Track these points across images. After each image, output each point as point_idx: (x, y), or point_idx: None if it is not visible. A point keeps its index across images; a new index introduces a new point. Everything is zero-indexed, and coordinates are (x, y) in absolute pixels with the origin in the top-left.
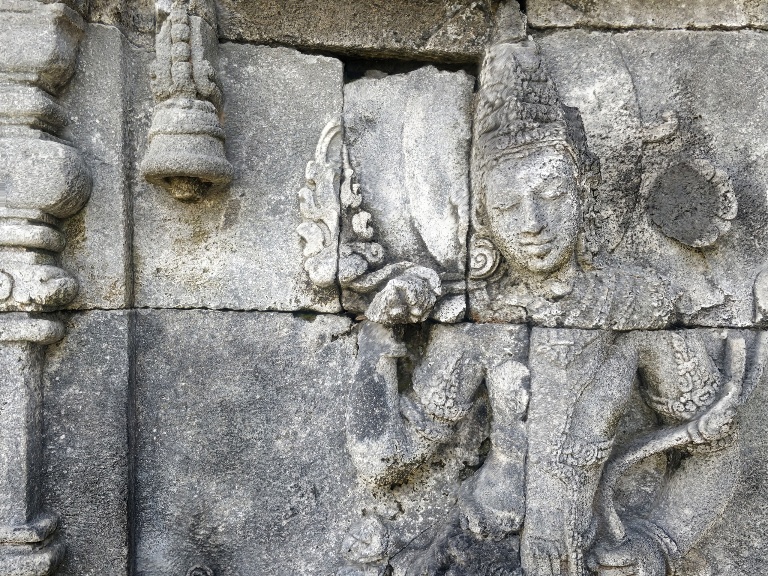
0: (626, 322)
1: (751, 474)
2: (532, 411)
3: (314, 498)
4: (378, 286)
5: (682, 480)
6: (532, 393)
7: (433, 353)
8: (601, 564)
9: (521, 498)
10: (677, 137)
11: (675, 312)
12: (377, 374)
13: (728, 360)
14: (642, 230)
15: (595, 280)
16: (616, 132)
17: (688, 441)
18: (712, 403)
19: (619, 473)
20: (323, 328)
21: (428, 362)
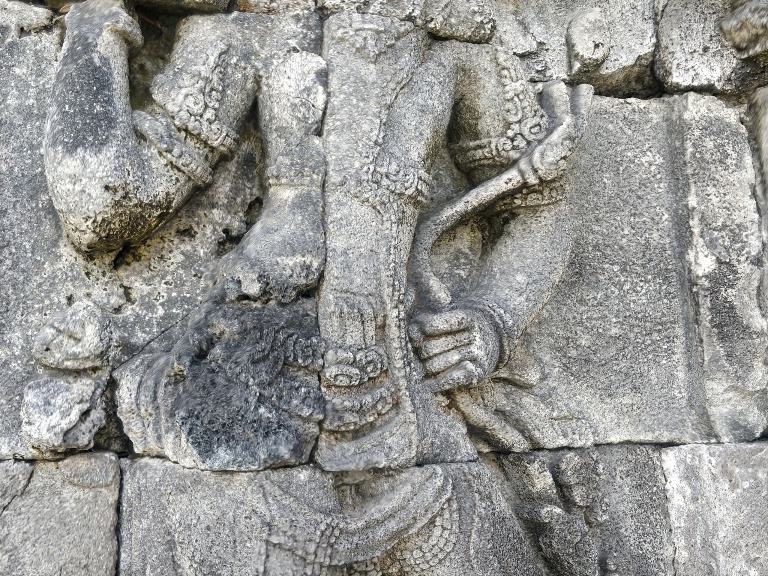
0: (443, 22)
1: (573, 258)
2: (331, 117)
3: None
4: None
5: (509, 245)
6: (331, 92)
7: (183, 52)
8: (427, 332)
9: (319, 236)
10: None
11: None
12: (99, 54)
13: (548, 109)
14: None
15: None
16: None
17: (520, 183)
18: (544, 137)
19: (435, 233)
20: (6, 18)
21: (175, 65)
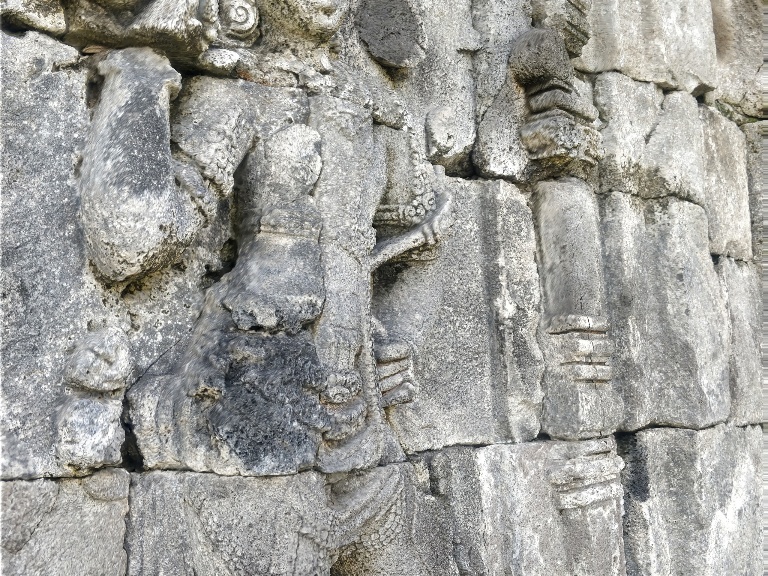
0: None
1: None
2: (324, 182)
3: (21, 301)
4: (137, 2)
5: (405, 290)
6: (324, 161)
7: (199, 108)
8: (382, 359)
9: (320, 280)
10: None
11: None
12: (159, 106)
13: None
14: (353, 45)
15: None
16: None
17: (423, 243)
18: (436, 208)
19: None
20: (38, 50)
21: (192, 119)
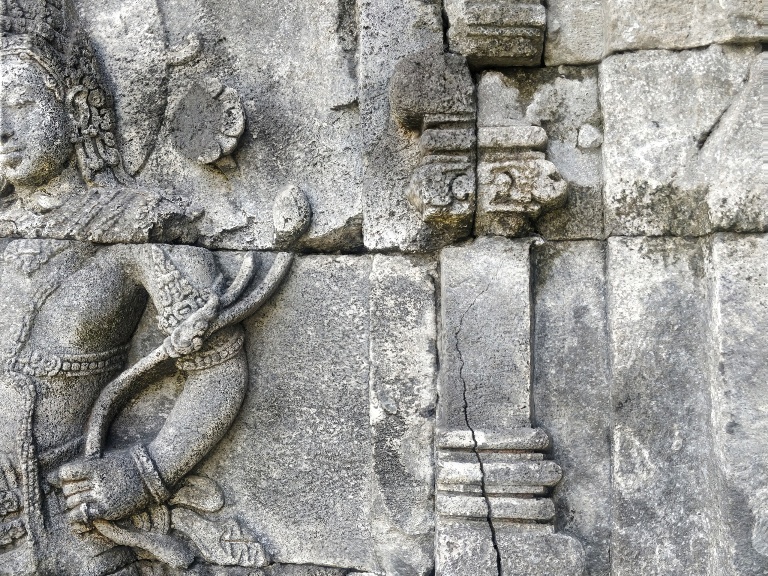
0: (104, 234)
1: (274, 402)
2: None
3: None
4: None
5: (178, 401)
6: None
7: None
8: (60, 479)
9: None
10: (202, 59)
11: (190, 233)
12: None
13: None
14: (167, 152)
15: (92, 196)
16: (141, 55)
17: (166, 356)
18: None
19: (113, 393)
20: None
21: None
